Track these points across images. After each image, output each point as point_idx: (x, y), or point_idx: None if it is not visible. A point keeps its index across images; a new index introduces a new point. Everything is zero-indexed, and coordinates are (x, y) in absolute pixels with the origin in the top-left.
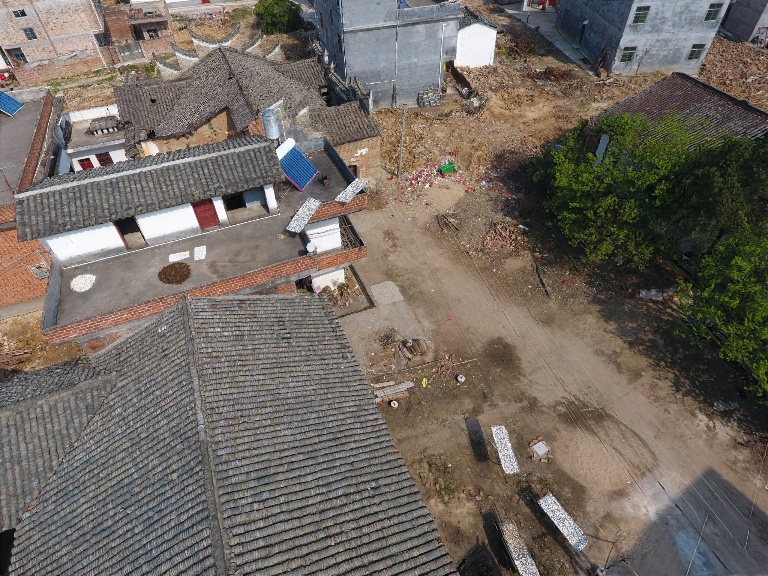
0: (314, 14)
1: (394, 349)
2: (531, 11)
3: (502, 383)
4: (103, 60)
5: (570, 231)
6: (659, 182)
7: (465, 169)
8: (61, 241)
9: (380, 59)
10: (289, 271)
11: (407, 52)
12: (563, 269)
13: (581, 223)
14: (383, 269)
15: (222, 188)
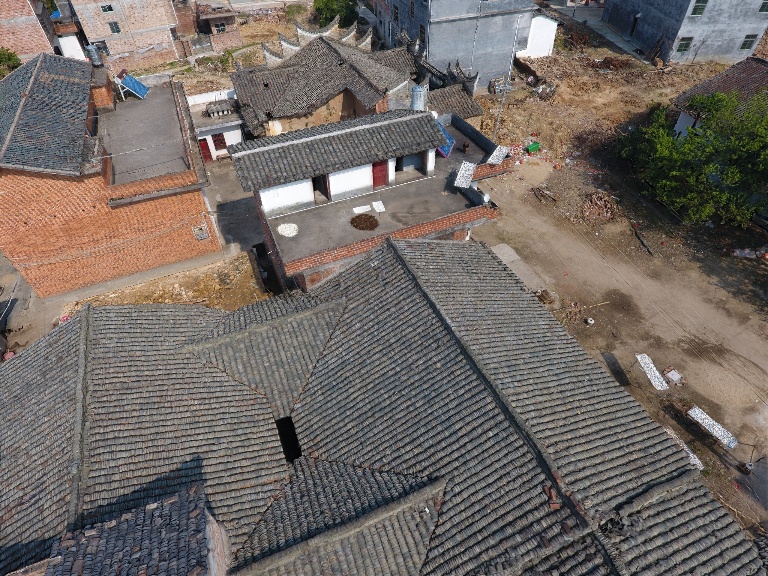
0: (364, 10)
1: None
2: (574, 6)
3: (627, 325)
4: (176, 53)
5: (667, 198)
6: (762, 149)
7: (548, 148)
8: (270, 194)
9: (459, 49)
10: (467, 219)
11: (484, 42)
12: (659, 233)
13: (679, 190)
14: (495, 234)
15: (400, 150)
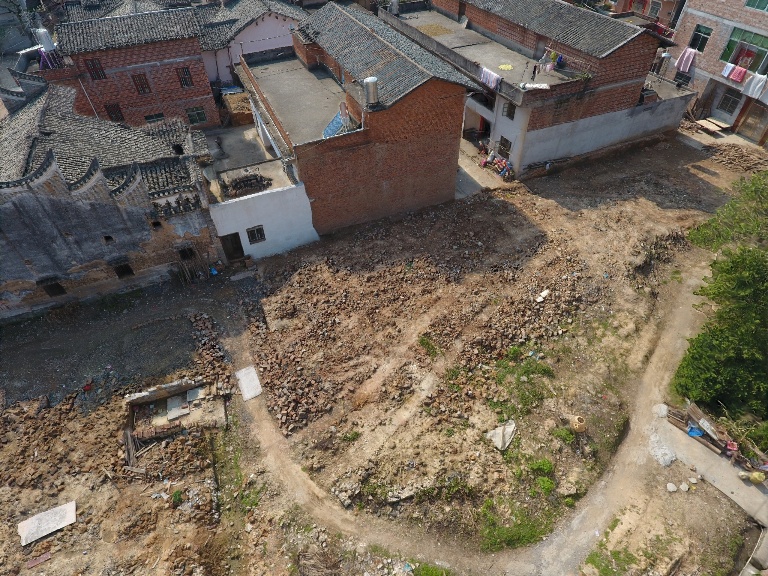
0: None
1: None
2: None
3: None
4: None
5: None
6: None
7: None
8: None
9: None
10: None
11: None
12: None
13: None
14: None
15: None
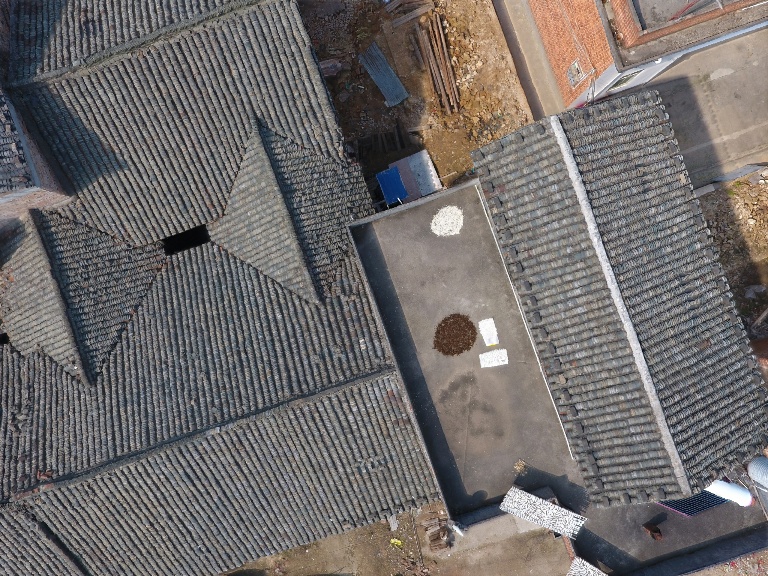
0: None
1: (443, 513)
2: None
3: None
4: None
5: None
6: None
7: None
8: None
9: None
10: None
11: None
12: None
13: None
14: None
15: (573, 416)
